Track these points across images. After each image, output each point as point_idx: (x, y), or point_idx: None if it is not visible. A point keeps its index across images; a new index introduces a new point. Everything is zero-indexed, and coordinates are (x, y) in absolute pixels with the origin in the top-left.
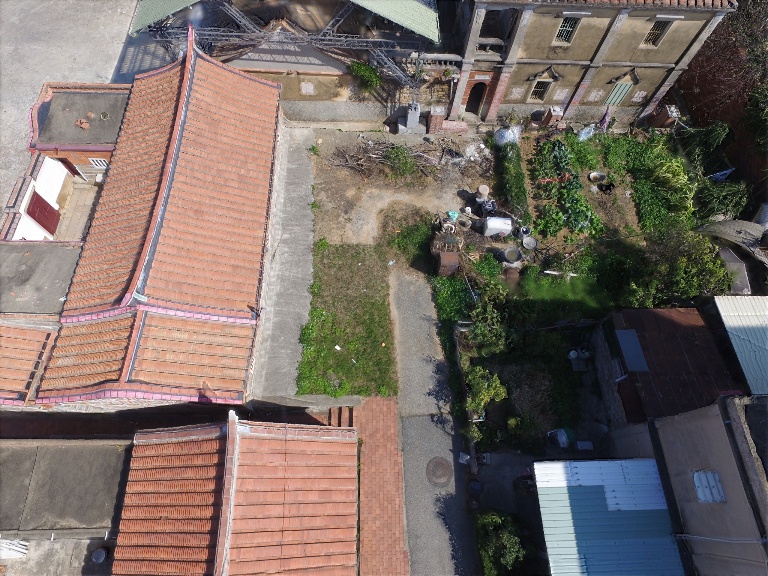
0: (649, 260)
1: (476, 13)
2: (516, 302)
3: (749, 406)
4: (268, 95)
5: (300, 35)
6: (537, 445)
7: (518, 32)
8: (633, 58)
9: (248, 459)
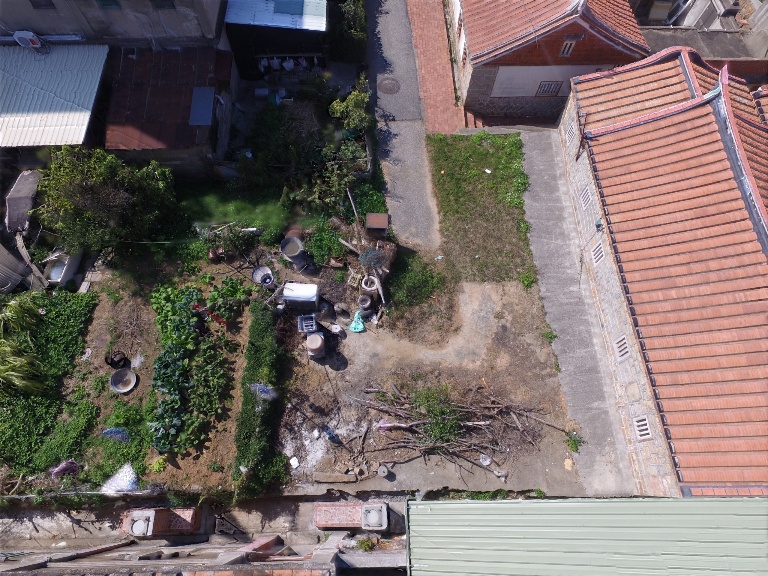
0: None
1: None
2: None
3: None
4: (697, 460)
5: None
6: (304, 96)
7: None
8: None
9: (560, 2)
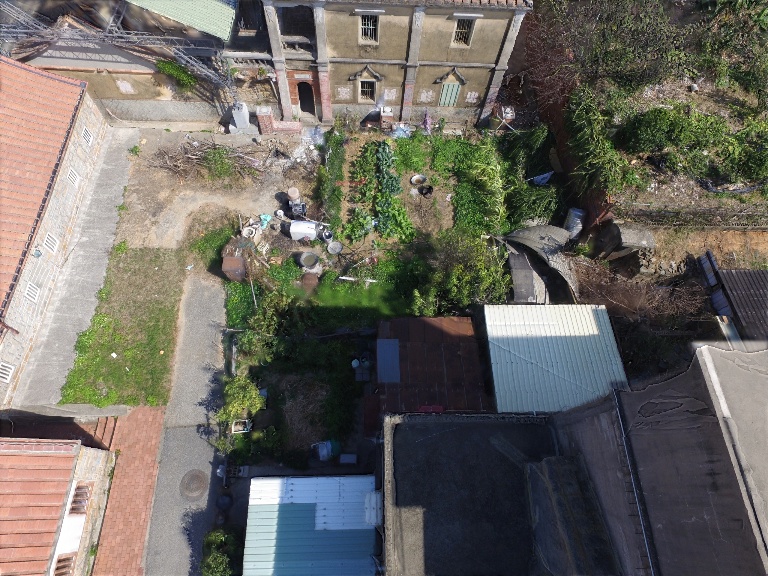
0: (431, 266)
1: (265, 10)
2: (300, 309)
3: (403, 424)
4: (67, 94)
5: (92, 32)
6: (300, 458)
7: (317, 30)
8: (449, 58)
9: None
